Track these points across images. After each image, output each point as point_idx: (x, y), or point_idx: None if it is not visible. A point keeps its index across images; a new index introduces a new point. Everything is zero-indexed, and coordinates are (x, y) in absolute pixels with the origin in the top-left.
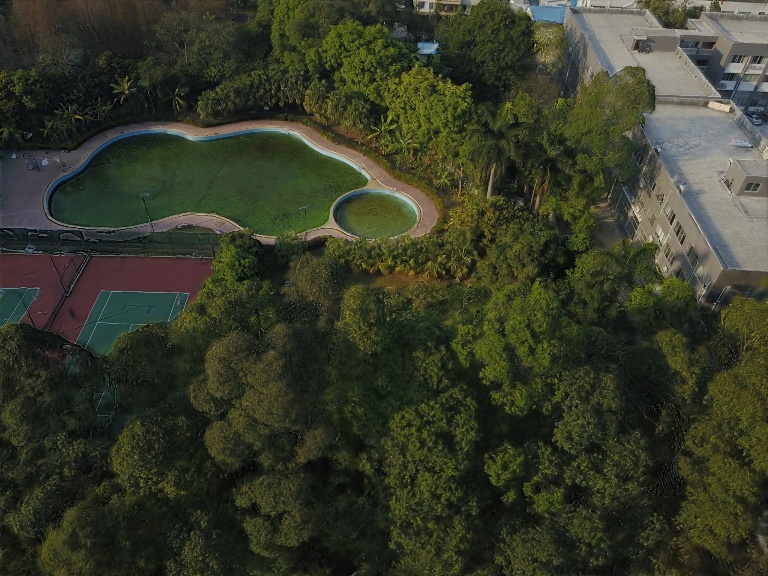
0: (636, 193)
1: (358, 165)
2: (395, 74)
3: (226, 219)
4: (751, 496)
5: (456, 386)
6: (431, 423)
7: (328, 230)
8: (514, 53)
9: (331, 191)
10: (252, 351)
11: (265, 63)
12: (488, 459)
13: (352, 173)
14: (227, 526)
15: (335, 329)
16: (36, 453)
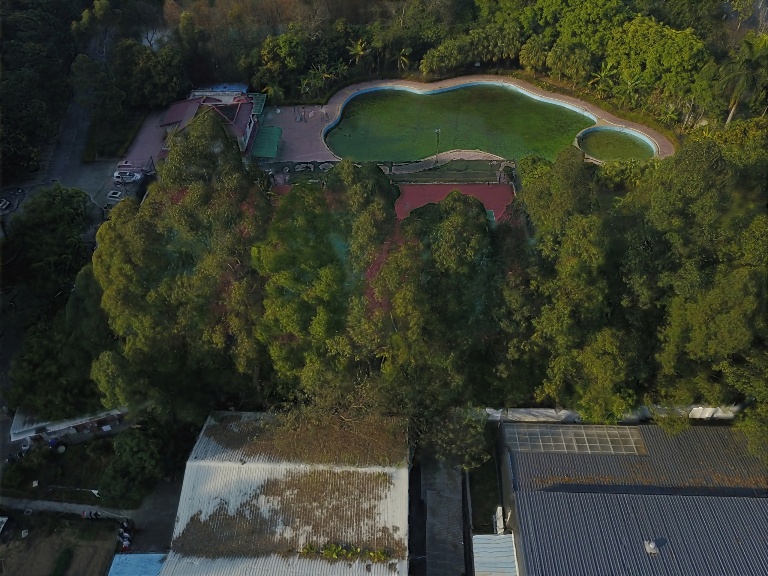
0: None
1: (580, 108)
2: (618, 24)
3: (490, 154)
4: None
5: None
6: None
7: None
8: (711, 3)
9: (564, 130)
10: None
11: (476, 24)
12: None
13: (576, 115)
14: None
15: None
16: (684, 241)
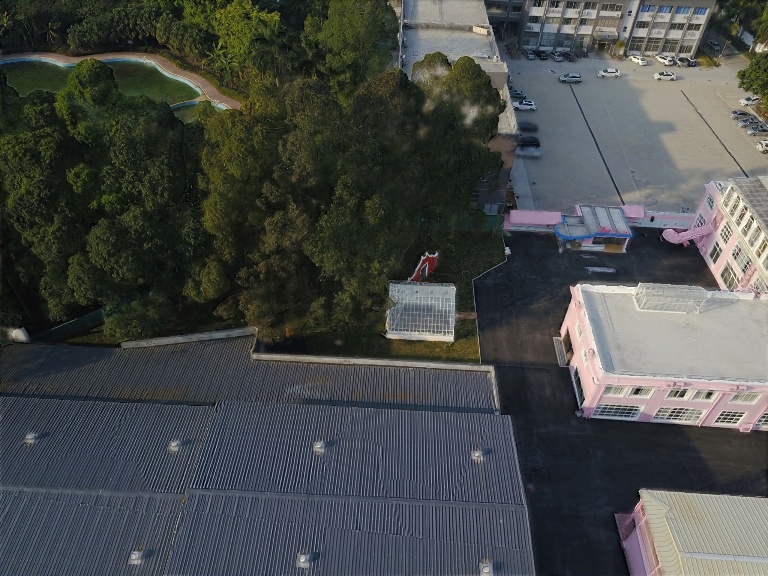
0: None
1: (195, 84)
2: (221, 6)
3: None
4: (231, 193)
5: (51, 127)
6: (23, 143)
7: None
8: None
9: None
10: None
11: (128, 3)
12: (68, 172)
13: (189, 91)
14: None
15: None
16: None
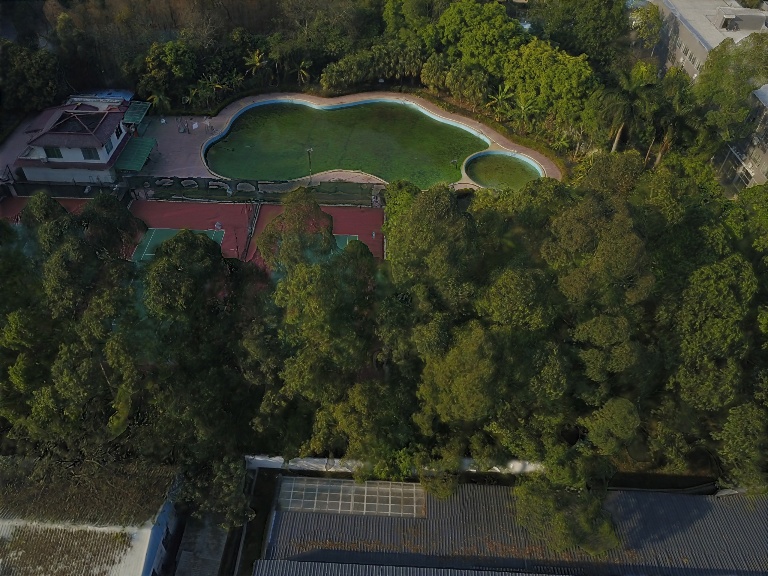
0: (747, 151)
1: (476, 131)
2: (514, 47)
3: (371, 175)
4: None
5: (734, 253)
6: (724, 277)
7: (465, 185)
8: (615, 30)
9: (456, 153)
10: (602, 214)
11: (381, 39)
12: (762, 309)
13: (472, 138)
14: (567, 356)
15: (648, 204)
16: (429, 294)
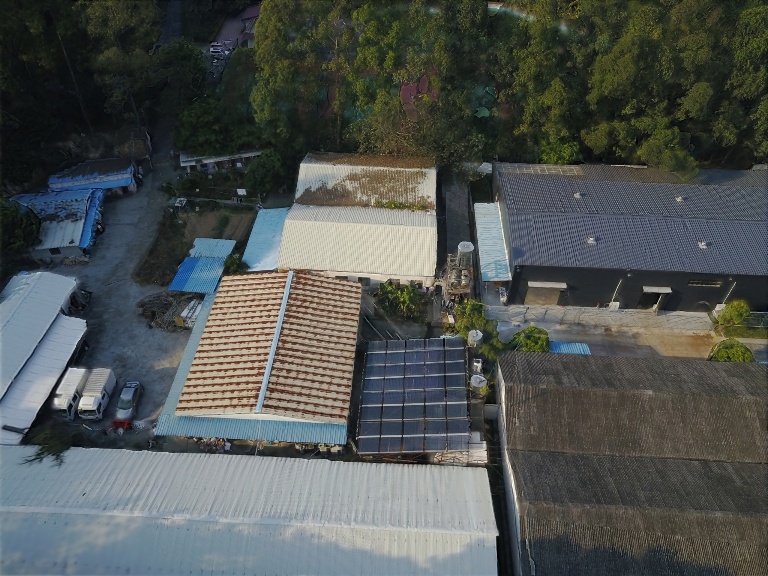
0: None
1: None
2: None
3: None
4: None
5: (764, 5)
6: (759, 14)
7: None
8: None
9: None
10: None
11: None
12: None
13: None
14: None
15: None
16: None
